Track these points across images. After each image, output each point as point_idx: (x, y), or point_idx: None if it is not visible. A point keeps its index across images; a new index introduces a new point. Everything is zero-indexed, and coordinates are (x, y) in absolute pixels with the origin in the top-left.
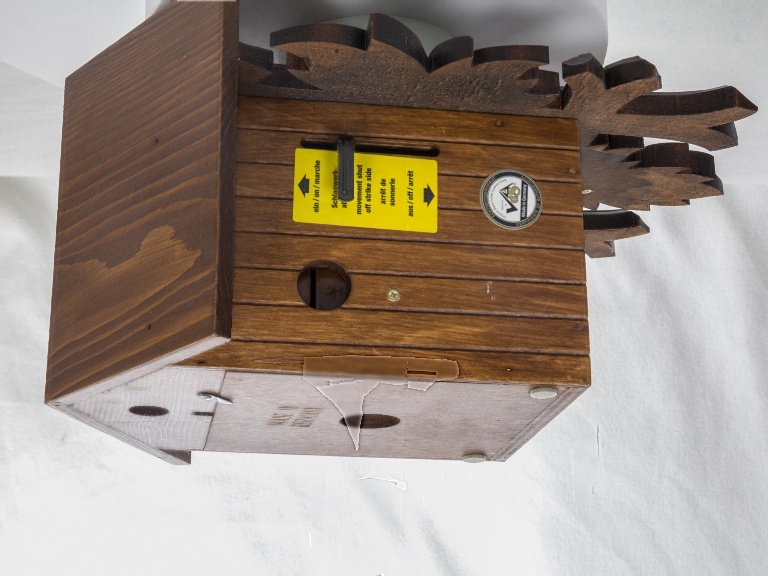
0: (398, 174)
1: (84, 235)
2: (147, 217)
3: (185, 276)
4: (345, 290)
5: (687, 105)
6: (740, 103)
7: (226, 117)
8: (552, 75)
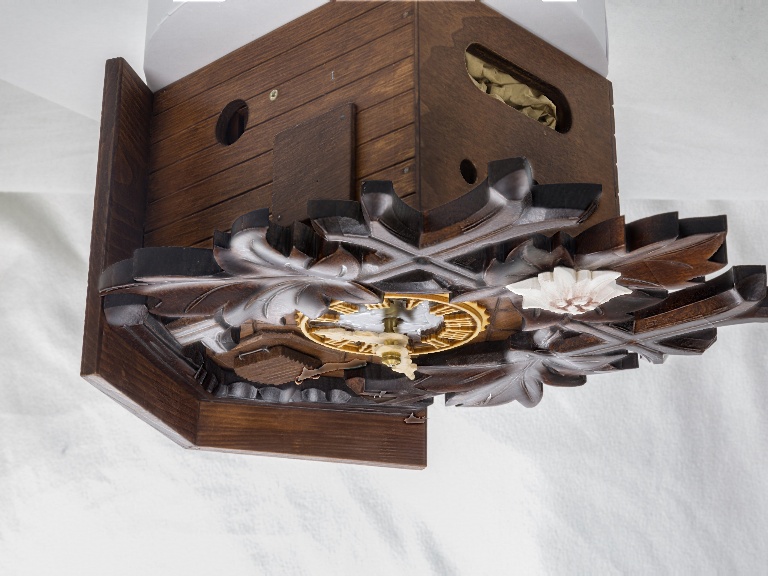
0: None
1: None
2: None
3: None
4: None
5: None
6: None
7: None
8: None
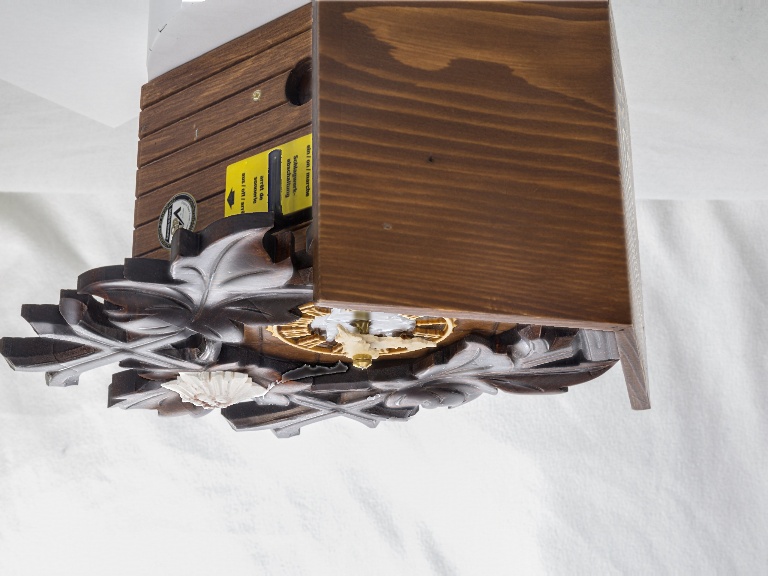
0: (251, 209)
1: (559, 119)
2: (440, 87)
3: (369, 2)
4: (300, 97)
5: (46, 345)
6: (1, 341)
7: (316, 136)
8: (114, 318)
